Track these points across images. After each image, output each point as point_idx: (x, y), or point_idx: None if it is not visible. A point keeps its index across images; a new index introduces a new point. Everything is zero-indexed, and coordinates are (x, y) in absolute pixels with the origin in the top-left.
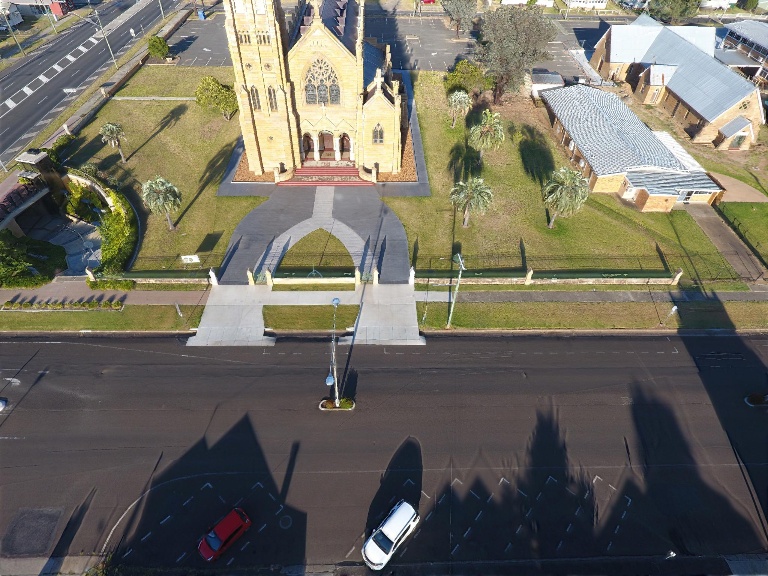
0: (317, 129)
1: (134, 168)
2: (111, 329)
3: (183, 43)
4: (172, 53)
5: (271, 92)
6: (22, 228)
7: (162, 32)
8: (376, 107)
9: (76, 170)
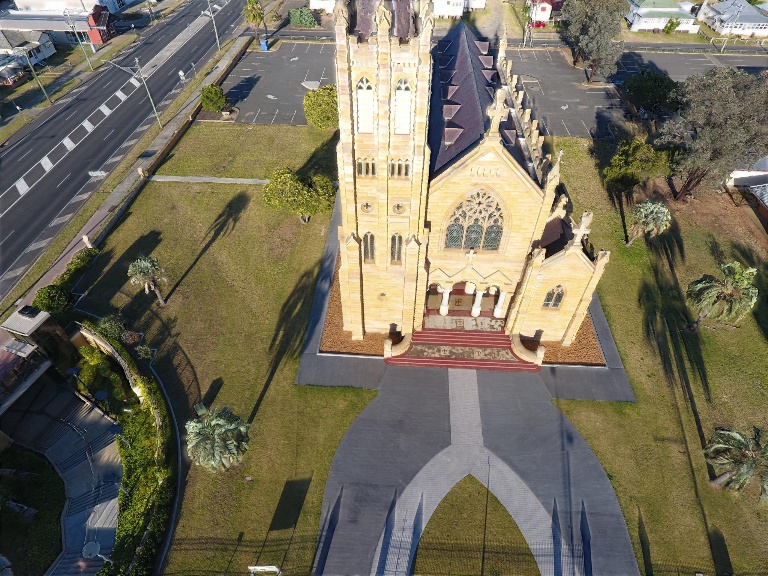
0: (453, 280)
1: (176, 318)
2: None
3: (243, 87)
4: (229, 102)
5: (395, 239)
6: (13, 410)
7: (217, 69)
8: (564, 265)
9: (92, 330)
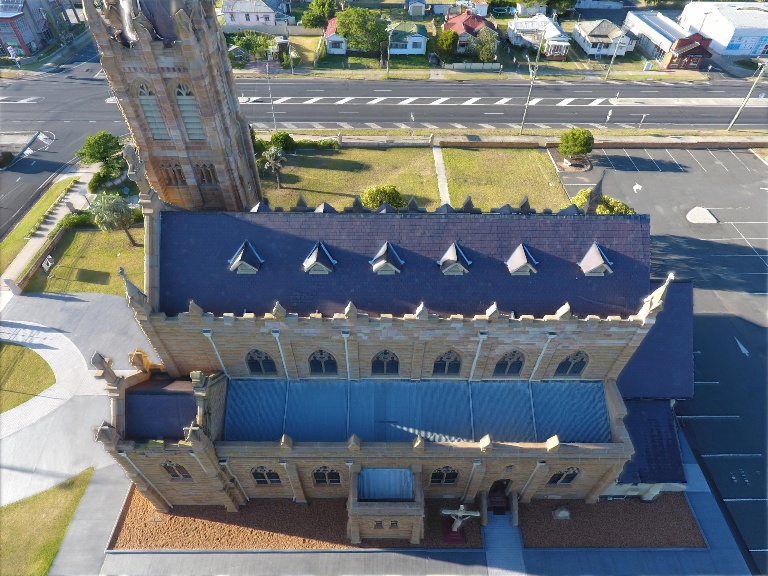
0: None
1: None
2: (6, 238)
3: (645, 163)
4: (600, 161)
5: None
6: None
7: (672, 139)
8: None
9: None
